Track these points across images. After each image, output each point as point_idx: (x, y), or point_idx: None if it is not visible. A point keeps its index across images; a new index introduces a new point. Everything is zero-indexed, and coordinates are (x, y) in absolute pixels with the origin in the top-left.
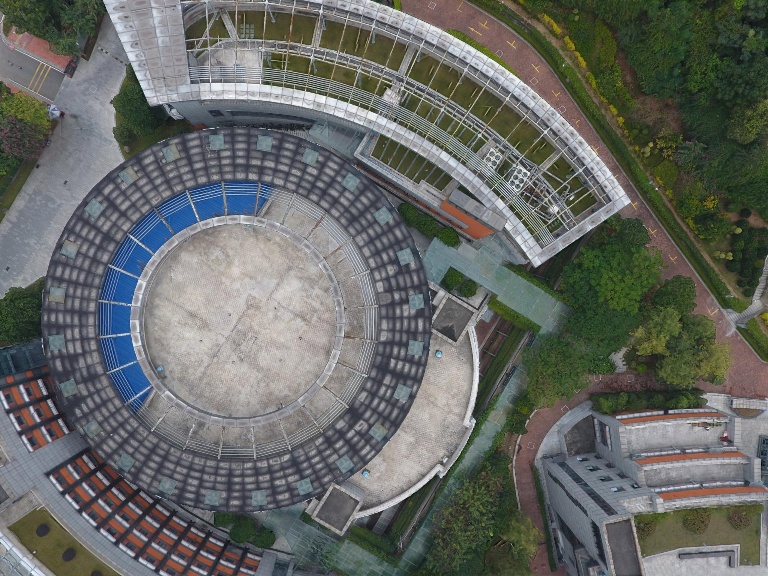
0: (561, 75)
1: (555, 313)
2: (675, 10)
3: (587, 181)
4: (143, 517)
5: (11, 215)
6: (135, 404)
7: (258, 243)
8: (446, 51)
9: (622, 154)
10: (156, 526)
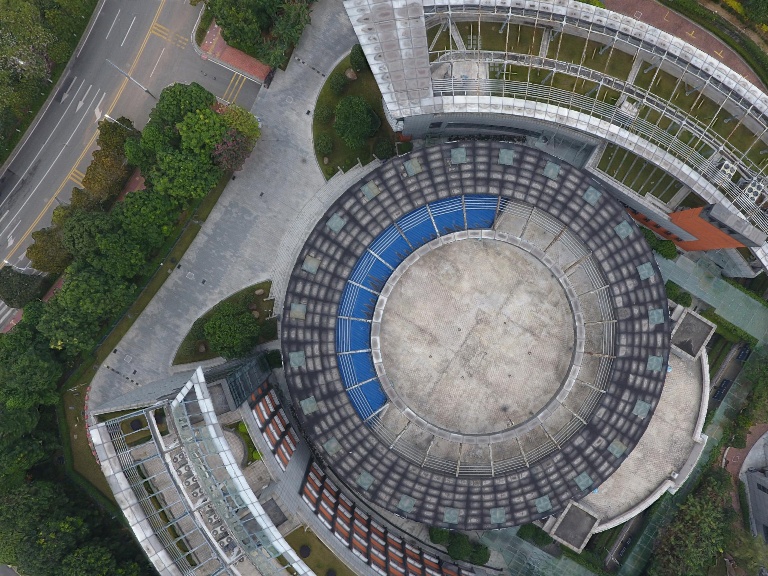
0: None
1: None
2: None
3: None
4: (369, 535)
5: (207, 227)
6: (373, 421)
7: (488, 257)
8: (688, 63)
9: None
10: (382, 544)
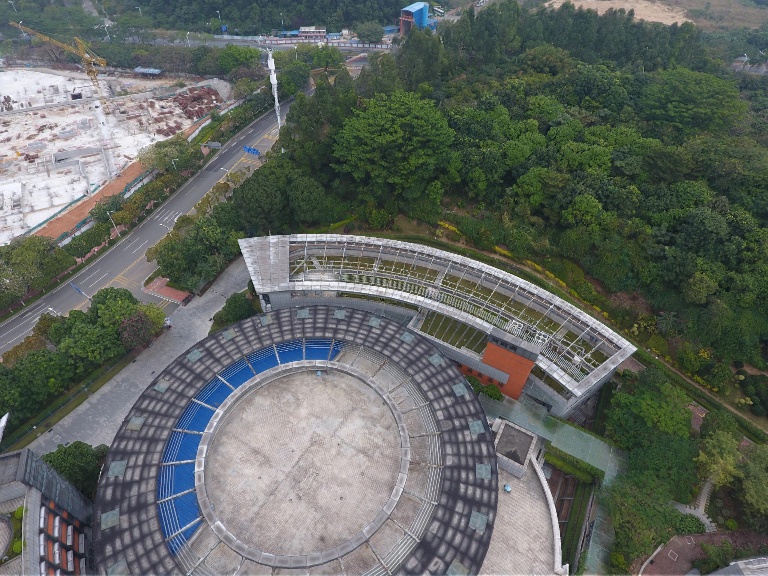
0: None
1: (613, 458)
2: None
3: (596, 336)
4: None
5: (93, 398)
6: (177, 540)
7: (326, 389)
8: (467, 266)
9: None
10: None
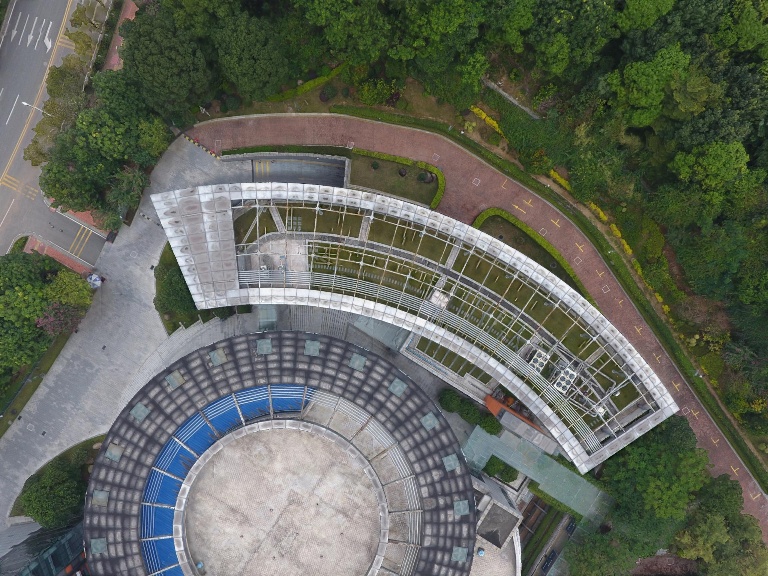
0: (605, 257)
1: (597, 502)
2: (730, 232)
3: None
4: None
5: (49, 379)
6: None
7: (301, 439)
8: (496, 257)
9: (666, 339)
10: None
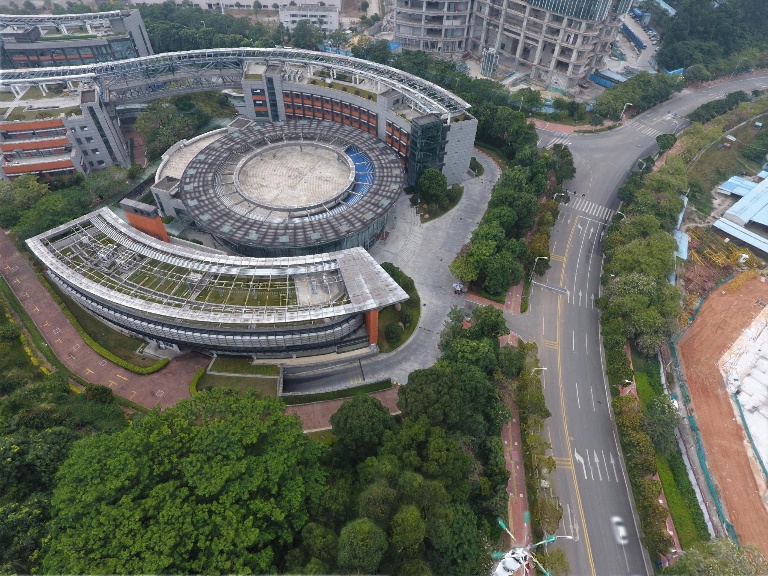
0: None
1: None
2: None
3: None
4: None
5: None
6: None
7: None
8: None
9: (15, 301)
10: None
